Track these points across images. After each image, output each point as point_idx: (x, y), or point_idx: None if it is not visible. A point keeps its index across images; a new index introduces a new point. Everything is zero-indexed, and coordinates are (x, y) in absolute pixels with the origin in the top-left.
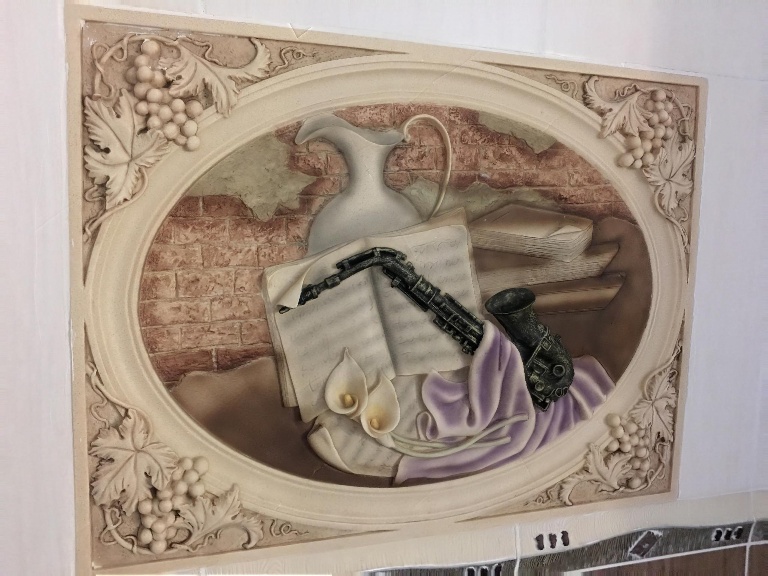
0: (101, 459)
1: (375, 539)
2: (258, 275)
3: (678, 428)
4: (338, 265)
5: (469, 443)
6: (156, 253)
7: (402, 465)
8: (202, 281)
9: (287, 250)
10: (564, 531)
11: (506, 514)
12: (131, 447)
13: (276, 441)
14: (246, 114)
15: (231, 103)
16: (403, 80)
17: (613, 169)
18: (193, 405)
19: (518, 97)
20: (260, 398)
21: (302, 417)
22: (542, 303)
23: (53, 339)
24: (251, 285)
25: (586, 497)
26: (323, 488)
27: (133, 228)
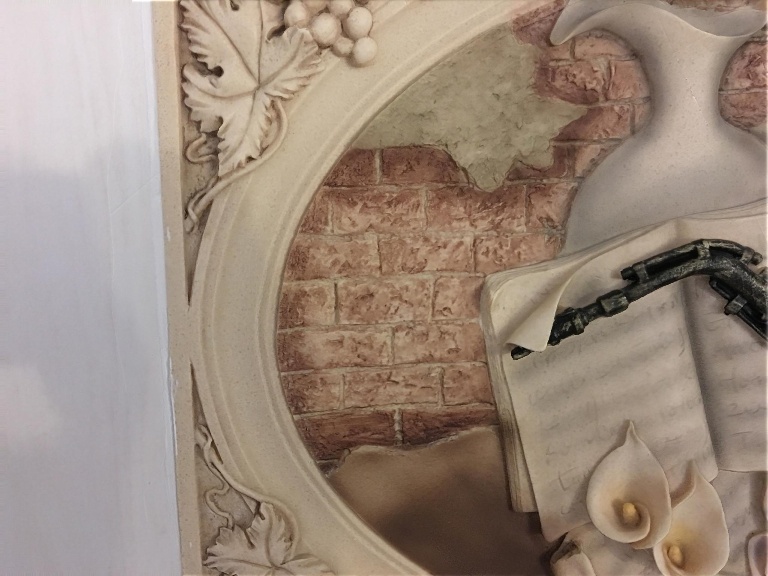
0: (222, 572)
1: None
2: (474, 287)
3: None
4: (625, 273)
5: None
6: (302, 249)
7: None
8: (378, 297)
9: (527, 243)
10: None
11: None
12: (265, 562)
13: (497, 563)
14: None
15: None
16: None
17: None
18: (362, 500)
19: None
20: (472, 493)
21: (544, 532)
22: None
23: (145, 389)
24: (462, 305)
25: None
26: None
27: (265, 207)
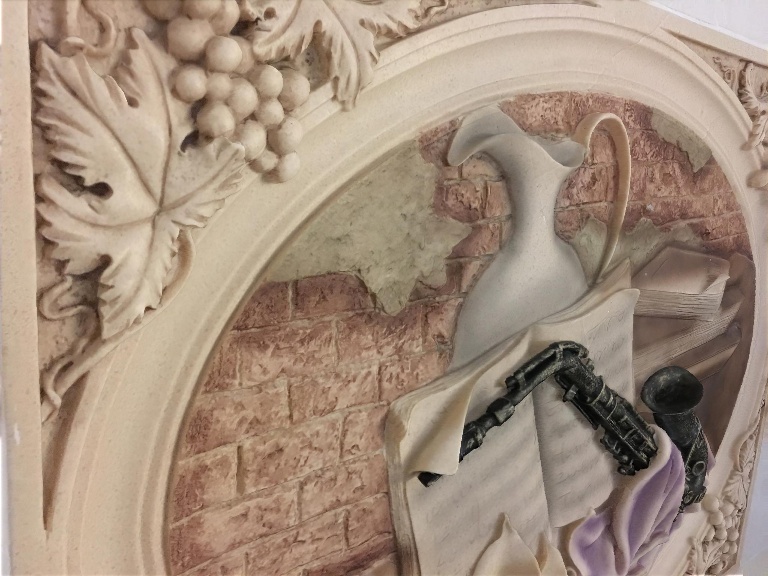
0: None
1: None
2: (380, 418)
3: (751, 493)
4: (510, 383)
5: None
6: (205, 414)
7: None
8: (288, 451)
9: (424, 363)
10: None
11: None
12: None
13: None
14: (373, 103)
15: (364, 81)
16: (582, 51)
17: (745, 190)
18: None
19: (686, 88)
20: None
21: None
22: None
23: None
24: (368, 438)
25: None
26: None
27: (152, 365)
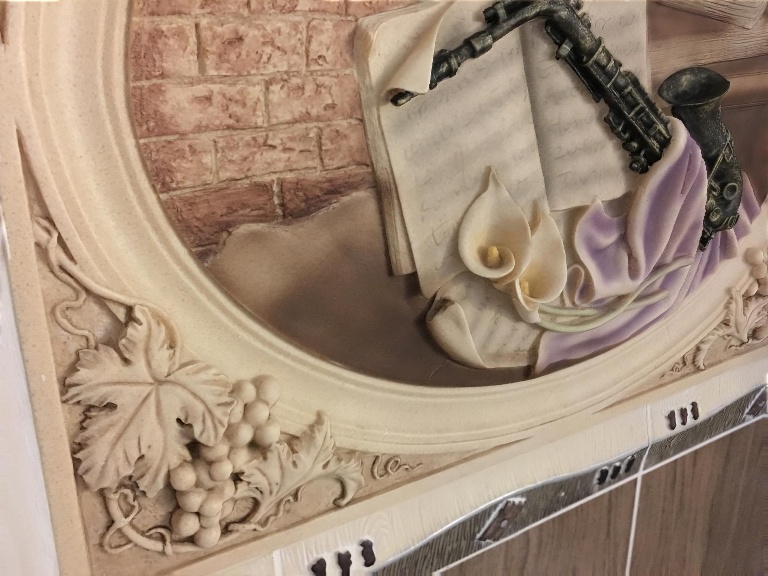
0: (88, 407)
1: (505, 455)
2: (347, 32)
3: None
4: (488, 13)
5: (627, 304)
6: None
7: (543, 346)
8: (248, 41)
9: None
10: (693, 402)
11: (643, 392)
12: (147, 377)
13: (380, 333)
14: None
15: None
16: None
17: None
18: (248, 287)
19: None
20: (355, 264)
21: (422, 290)
22: None
23: None
24: (336, 52)
25: (716, 357)
26: (440, 396)
27: None
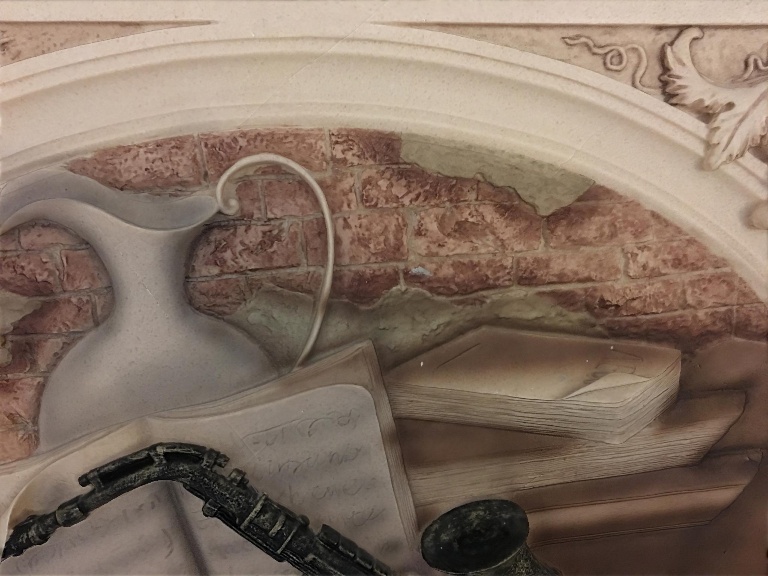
0: None
1: None
2: None
3: None
4: (80, 481)
5: None
6: None
7: None
8: None
9: None
10: None
11: None
12: None
13: None
14: None
15: None
16: (219, 81)
17: (737, 234)
18: None
19: (497, 94)
20: None
21: None
22: (558, 523)
23: None
24: None
25: None
26: None
27: None
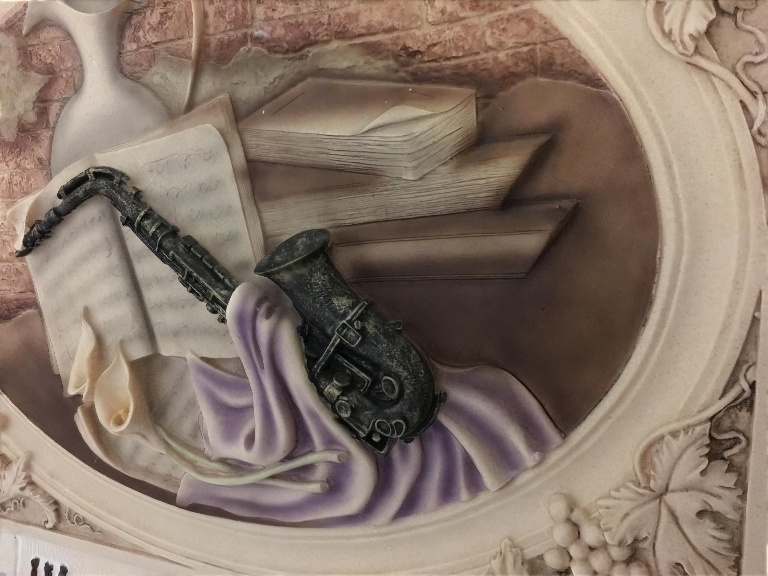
0: None
1: (168, 570)
2: None
3: (748, 570)
4: (57, 194)
5: (255, 476)
6: None
7: (185, 482)
8: None
9: (34, 176)
10: None
11: None
12: None
13: (54, 412)
14: None
15: None
16: None
17: None
18: None
19: None
20: (35, 358)
21: (63, 389)
22: (374, 258)
23: None
24: None
25: None
26: (111, 483)
27: None
